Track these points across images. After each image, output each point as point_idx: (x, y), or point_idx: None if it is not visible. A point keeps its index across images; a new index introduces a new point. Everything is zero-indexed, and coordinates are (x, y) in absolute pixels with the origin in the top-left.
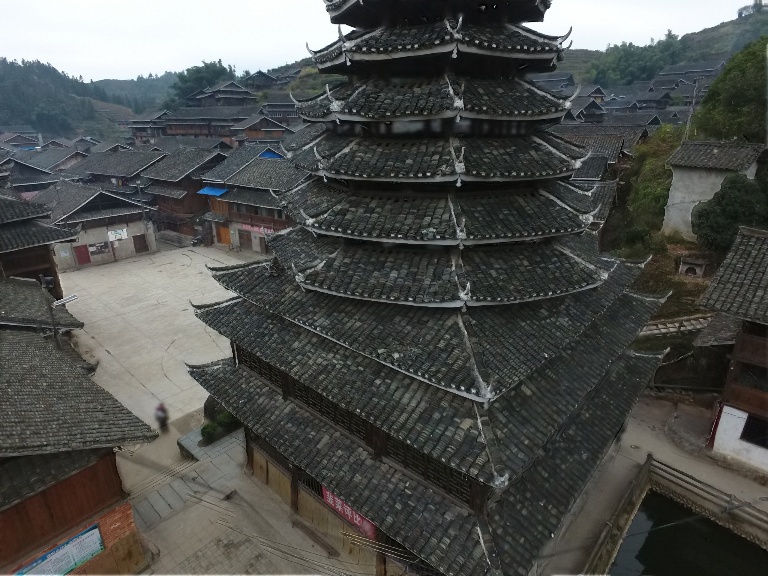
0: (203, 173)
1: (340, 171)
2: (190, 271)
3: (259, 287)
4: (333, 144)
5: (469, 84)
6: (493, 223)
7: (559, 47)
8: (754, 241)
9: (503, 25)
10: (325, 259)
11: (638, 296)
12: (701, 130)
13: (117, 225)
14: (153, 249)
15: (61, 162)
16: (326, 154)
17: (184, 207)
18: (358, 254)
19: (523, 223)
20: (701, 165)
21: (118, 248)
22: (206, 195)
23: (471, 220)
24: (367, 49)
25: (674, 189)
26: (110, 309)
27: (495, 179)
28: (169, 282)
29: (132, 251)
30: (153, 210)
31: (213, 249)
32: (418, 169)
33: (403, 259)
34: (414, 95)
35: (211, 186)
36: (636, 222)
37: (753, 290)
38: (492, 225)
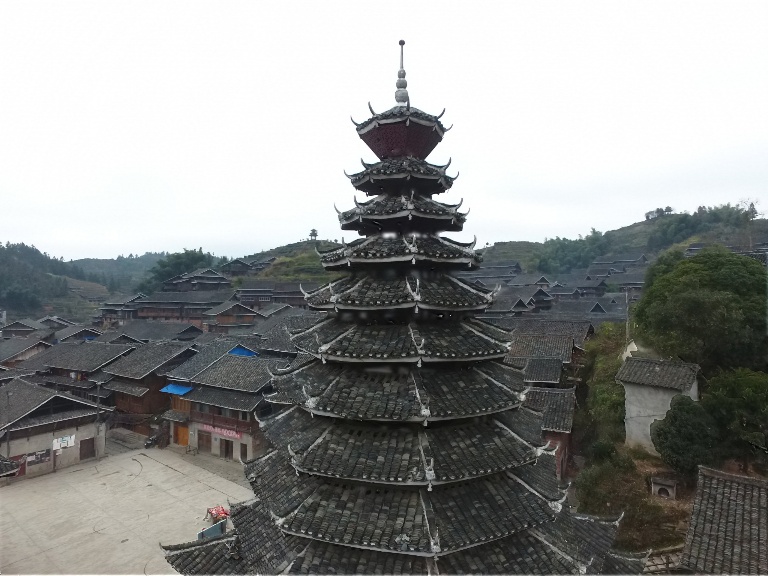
0: (169, 369)
1: (313, 469)
2: (138, 483)
3: (217, 575)
4: (306, 423)
5: (433, 382)
6: (466, 523)
7: (509, 349)
8: (716, 483)
9: (459, 324)
10: (293, 560)
11: (619, 556)
12: (640, 346)
13: (66, 429)
14: (100, 454)
15: (20, 353)
16: (299, 437)
17: (143, 404)
18: (328, 552)
19: (495, 519)
20: (648, 383)
21: (61, 455)
22: (169, 394)
23: (444, 522)
24: (341, 353)
25: (629, 403)
26: (34, 543)
27: (464, 478)
28: (112, 500)
29: (76, 458)
30: (109, 411)
31: (168, 451)
32: (390, 470)
33: (376, 560)
34: (384, 393)
35: (175, 383)
36: (600, 432)
37: (730, 545)
38: (465, 526)
